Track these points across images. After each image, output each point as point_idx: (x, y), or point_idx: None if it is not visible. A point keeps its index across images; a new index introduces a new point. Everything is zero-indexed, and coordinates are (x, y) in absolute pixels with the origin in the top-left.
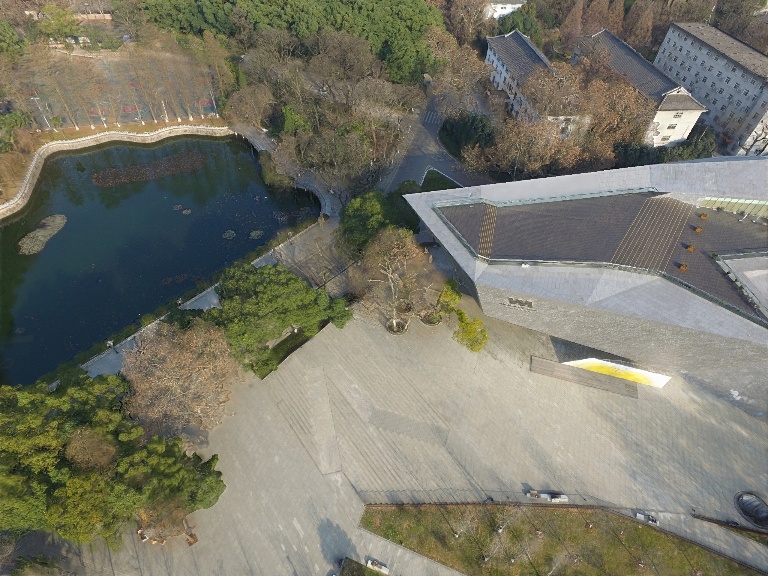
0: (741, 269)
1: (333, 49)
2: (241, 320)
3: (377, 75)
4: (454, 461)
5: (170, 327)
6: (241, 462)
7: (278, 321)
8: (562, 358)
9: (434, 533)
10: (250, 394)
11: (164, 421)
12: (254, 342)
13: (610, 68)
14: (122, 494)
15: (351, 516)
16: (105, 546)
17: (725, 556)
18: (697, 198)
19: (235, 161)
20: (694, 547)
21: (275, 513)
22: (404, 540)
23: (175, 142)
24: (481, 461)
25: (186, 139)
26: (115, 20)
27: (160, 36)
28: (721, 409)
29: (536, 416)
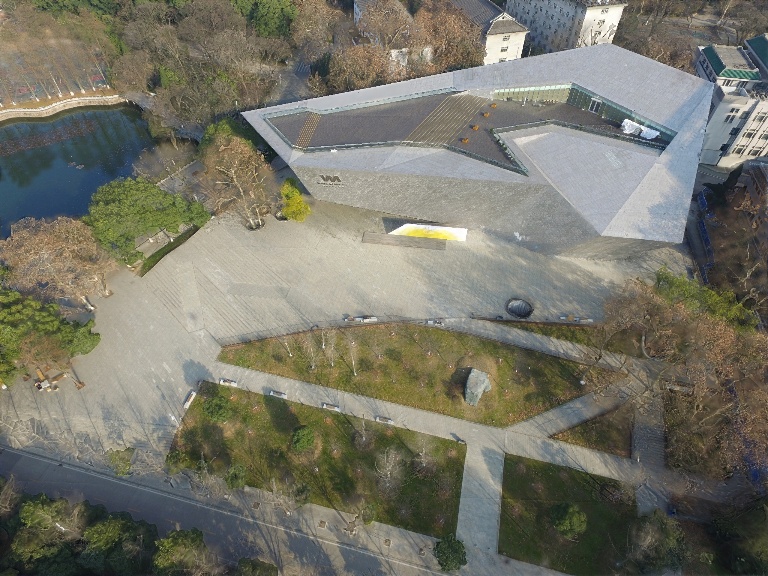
0: (511, 137)
1: (199, 12)
2: (106, 220)
3: (244, 32)
4: (291, 307)
5: (38, 222)
6: (122, 333)
7: (140, 220)
8: (389, 231)
9: (274, 356)
10: (131, 288)
11: (42, 293)
12: (121, 238)
13: (455, 6)
14: (1, 332)
15: (210, 355)
16: (9, 398)
17: (491, 339)
18: (489, 92)
19: (135, 130)
20: (468, 336)
21: (148, 361)
22: (251, 365)
23: (72, 115)
24: (313, 304)
25: (81, 111)
26: (3, 12)
27: (36, 14)
28: (509, 249)
29: (361, 271)
